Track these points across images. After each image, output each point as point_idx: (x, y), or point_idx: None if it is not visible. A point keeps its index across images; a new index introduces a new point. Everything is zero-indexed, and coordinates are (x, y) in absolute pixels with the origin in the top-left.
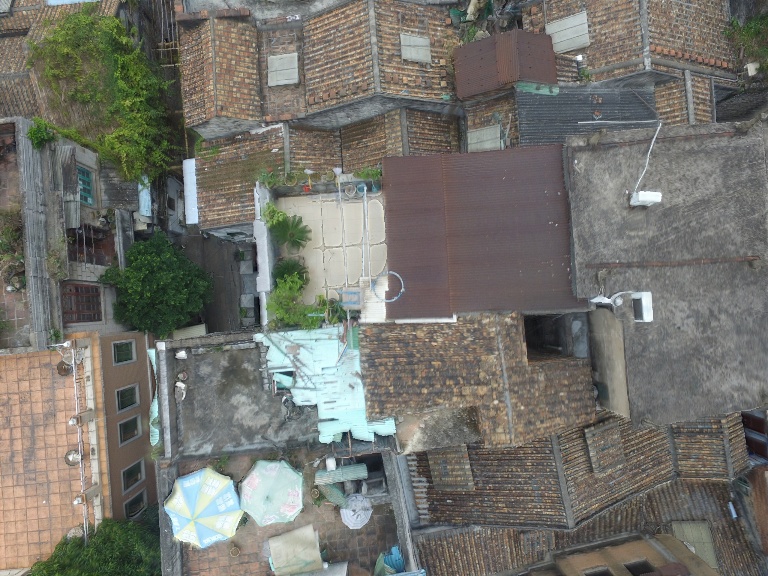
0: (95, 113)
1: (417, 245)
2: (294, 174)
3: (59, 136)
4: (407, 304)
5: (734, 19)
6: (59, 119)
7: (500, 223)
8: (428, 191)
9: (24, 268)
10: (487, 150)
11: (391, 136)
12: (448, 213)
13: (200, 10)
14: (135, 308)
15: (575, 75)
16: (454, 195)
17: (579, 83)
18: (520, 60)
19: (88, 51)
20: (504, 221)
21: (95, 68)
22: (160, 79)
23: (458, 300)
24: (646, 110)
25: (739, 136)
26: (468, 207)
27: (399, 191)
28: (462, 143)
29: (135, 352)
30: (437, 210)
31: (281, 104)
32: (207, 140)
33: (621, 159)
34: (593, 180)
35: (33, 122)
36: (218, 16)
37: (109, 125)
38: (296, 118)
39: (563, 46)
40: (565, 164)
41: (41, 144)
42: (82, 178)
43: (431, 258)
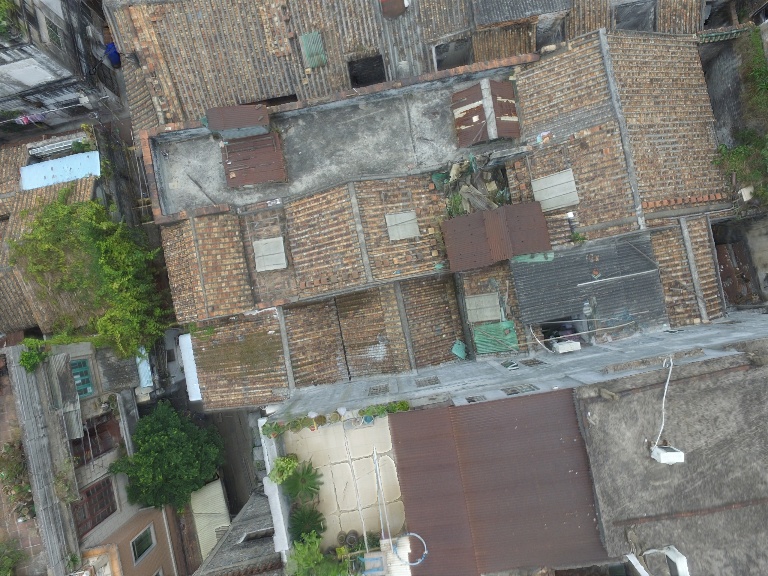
0: (84, 298)
1: (435, 504)
2: (298, 420)
3: (51, 344)
4: (432, 566)
5: (722, 147)
6: (48, 308)
7: (518, 475)
8: (439, 446)
9: (33, 502)
10: (488, 318)
11: (388, 309)
12: (463, 468)
13: (178, 202)
14: (149, 489)
15: (568, 234)
16: (467, 449)
17: (573, 244)
18: (511, 237)
19: (69, 243)
20: (522, 473)
21: (78, 257)
22: (145, 247)
23: (484, 560)
24: (645, 261)
25: (755, 368)
26: (483, 461)
27: (409, 448)
28: (460, 297)
29: (154, 535)
30: (451, 466)
31: (272, 287)
32: (201, 321)
33: (636, 406)
34: (609, 431)
35: (23, 345)
36: (198, 215)
37: (99, 307)
38: (289, 303)
39: (552, 203)
40: (578, 411)
41: (34, 365)
42: (79, 371)
43: (451, 516)
